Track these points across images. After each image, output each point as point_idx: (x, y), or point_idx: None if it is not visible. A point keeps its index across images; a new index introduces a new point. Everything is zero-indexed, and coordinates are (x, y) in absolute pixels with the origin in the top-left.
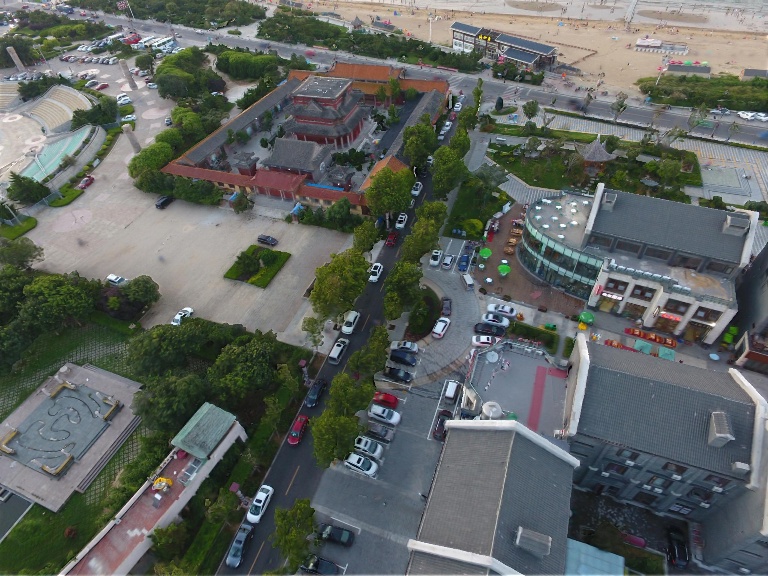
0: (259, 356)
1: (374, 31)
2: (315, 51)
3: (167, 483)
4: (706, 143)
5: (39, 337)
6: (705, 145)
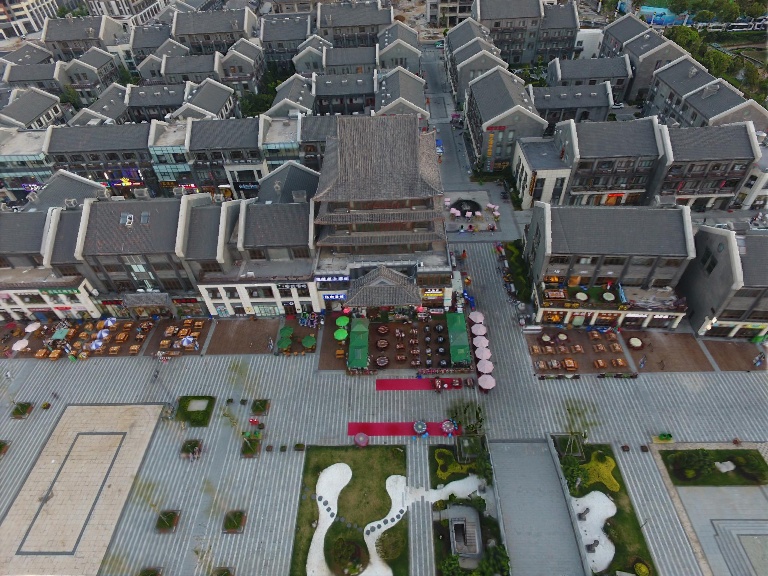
0: None
1: None
2: None
3: None
4: None
5: None
6: None
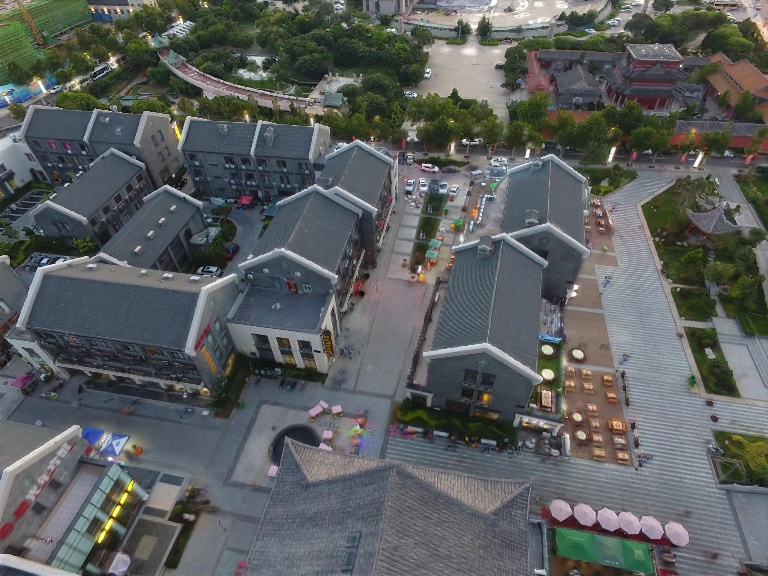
0: (375, 103)
1: None
2: None
3: None
4: None
5: (387, 70)
6: None
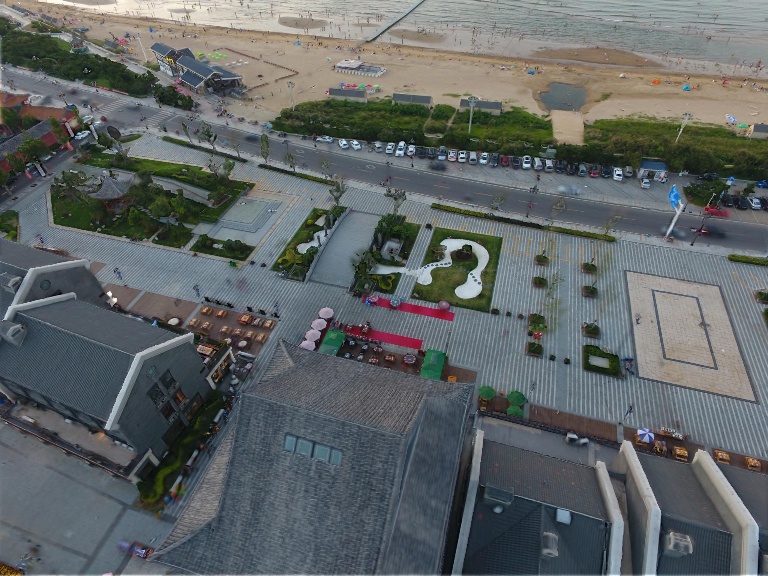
0: None
1: (97, 50)
2: (15, 72)
3: None
4: (278, 174)
5: None
6: (275, 176)
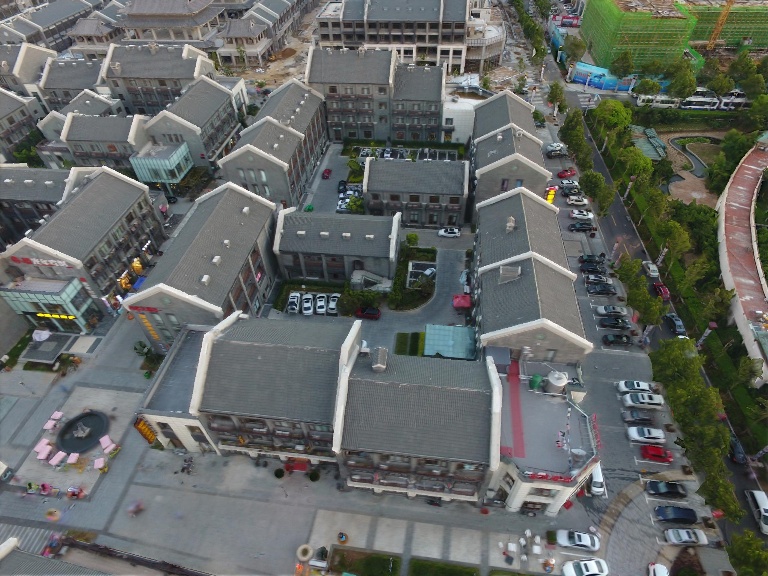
0: None
1: None
2: None
3: (765, 323)
4: None
5: None
6: None
